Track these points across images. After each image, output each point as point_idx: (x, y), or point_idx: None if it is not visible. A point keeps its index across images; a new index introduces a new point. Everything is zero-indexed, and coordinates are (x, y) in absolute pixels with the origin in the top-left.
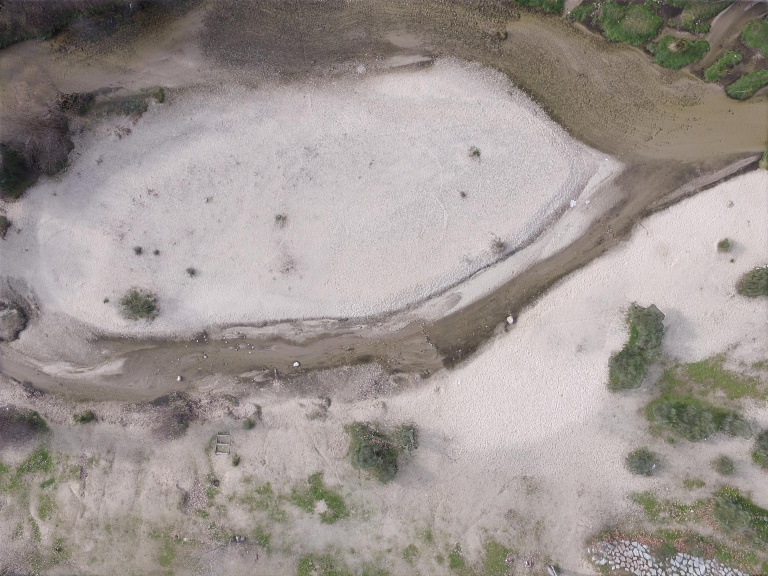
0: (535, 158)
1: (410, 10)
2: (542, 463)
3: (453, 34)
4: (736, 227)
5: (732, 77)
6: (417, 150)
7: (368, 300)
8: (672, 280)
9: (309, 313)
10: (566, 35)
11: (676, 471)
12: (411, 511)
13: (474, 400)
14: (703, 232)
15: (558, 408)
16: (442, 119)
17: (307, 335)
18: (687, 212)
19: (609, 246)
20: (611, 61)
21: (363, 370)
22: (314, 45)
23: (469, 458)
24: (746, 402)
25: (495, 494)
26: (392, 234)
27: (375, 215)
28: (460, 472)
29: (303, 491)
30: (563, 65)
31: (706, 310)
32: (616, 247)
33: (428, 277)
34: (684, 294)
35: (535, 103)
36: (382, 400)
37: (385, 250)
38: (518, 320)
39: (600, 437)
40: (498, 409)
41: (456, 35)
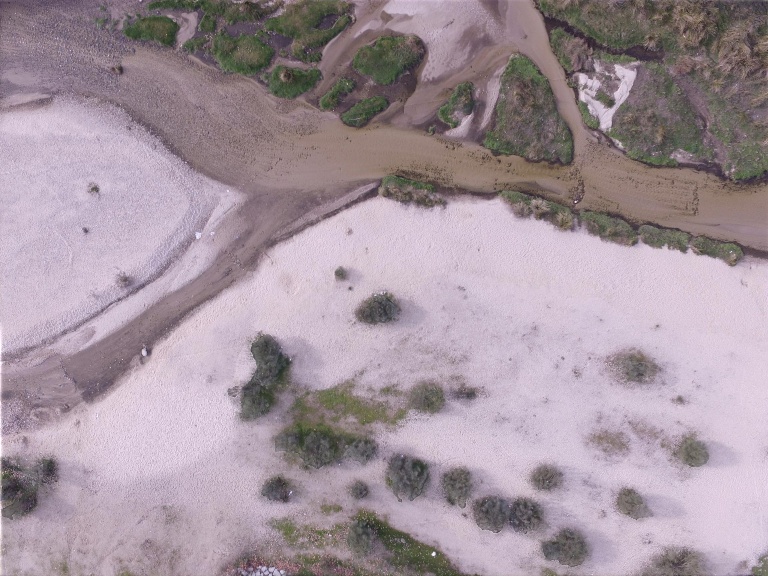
0: (153, 192)
1: (26, 48)
2: (181, 492)
3: (70, 71)
4: (354, 254)
5: (347, 105)
6: (37, 188)
7: (1, 337)
8: (294, 309)
9: None
10: (181, 68)
11: (313, 496)
12: (48, 544)
13: (111, 432)
14: (323, 260)
15: (193, 438)
16: (60, 156)
17: None
18: (309, 241)
19: (237, 276)
20: (227, 93)
21: (4, 406)
22: None
23: (109, 489)
24: (377, 427)
25: (133, 524)
26: (19, 272)
27: None
28: (100, 504)
29: None
30: (180, 98)
31: (330, 337)
32: (244, 277)
33: (57, 313)
34: (307, 322)
35: (154, 137)
36: (24, 435)
37: (13, 288)
38: (152, 352)
39: (236, 465)
40: (134, 441)
41: (73, 72)
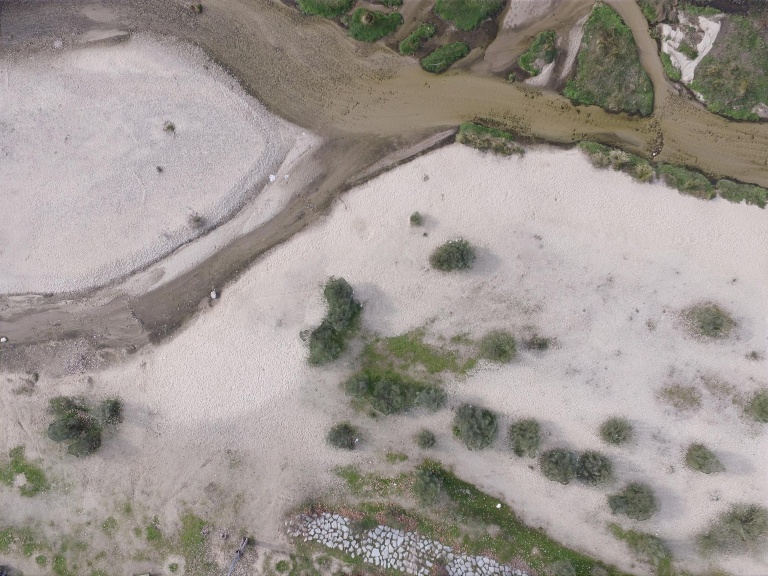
0: (229, 132)
1: None
2: (246, 437)
3: (149, 8)
4: (430, 201)
5: (427, 50)
6: (112, 125)
7: (70, 275)
8: (368, 254)
9: (13, 288)
10: (261, 8)
11: (379, 445)
12: (112, 484)
13: (178, 375)
14: (398, 206)
15: (260, 382)
16: (137, 93)
17: (13, 310)
18: (384, 186)
19: (310, 221)
20: (306, 34)
21: (70, 345)
22: (11, 20)
23: (174, 432)
24: (446, 376)
25: (198, 467)
26: (90, 209)
27: (72, 190)
28: (164, 446)
29: (4, 464)
30: (259, 39)
31: (402, 284)
32: (316, 221)
33: (128, 252)
34: (380, 268)
35: (231, 77)
36: (89, 375)
37: (84, 225)
38: (221, 295)
39: (303, 411)
40: (201, 383)
41: (152, 9)
